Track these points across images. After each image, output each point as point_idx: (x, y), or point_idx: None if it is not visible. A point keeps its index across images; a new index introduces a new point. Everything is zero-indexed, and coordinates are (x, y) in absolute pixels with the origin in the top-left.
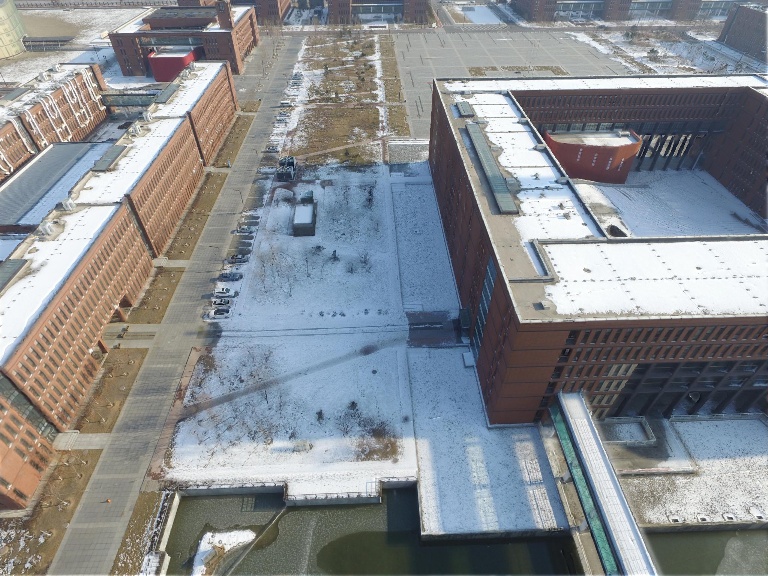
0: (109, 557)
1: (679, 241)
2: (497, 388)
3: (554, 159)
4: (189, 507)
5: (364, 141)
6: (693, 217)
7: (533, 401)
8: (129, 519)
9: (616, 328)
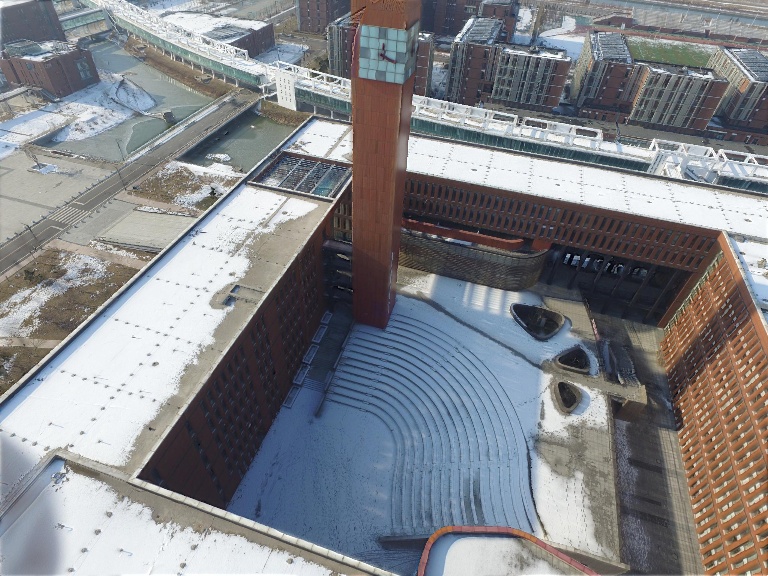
0: None
1: None
2: None
3: None
4: None
5: None
6: (382, 431)
7: None
8: None
9: None
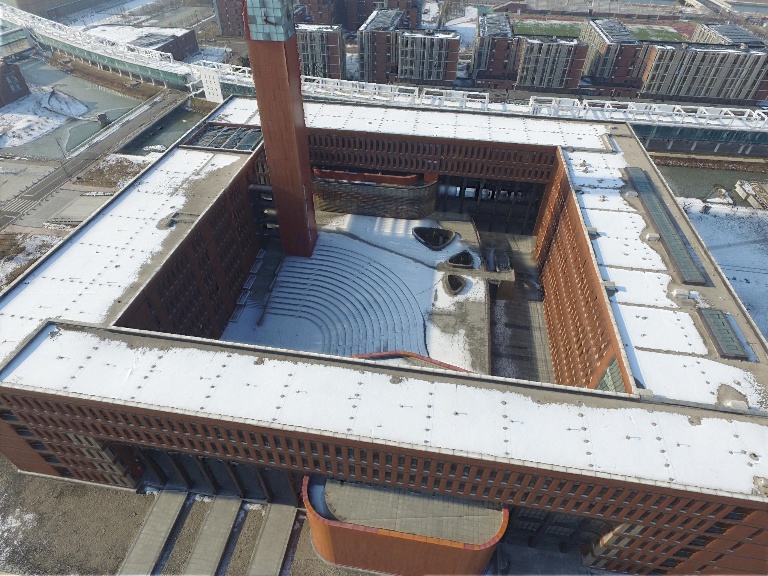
0: None
1: None
2: None
3: None
4: None
5: None
6: (313, 328)
7: None
8: None
9: None
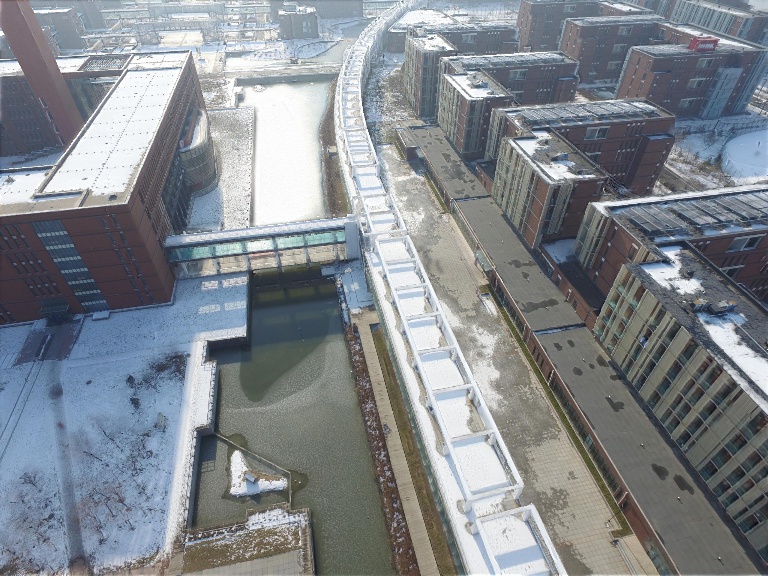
0: (248, 568)
1: (76, 144)
2: (151, 272)
3: None
4: (203, 523)
5: None
6: None
7: (164, 263)
8: (211, 569)
9: (143, 178)
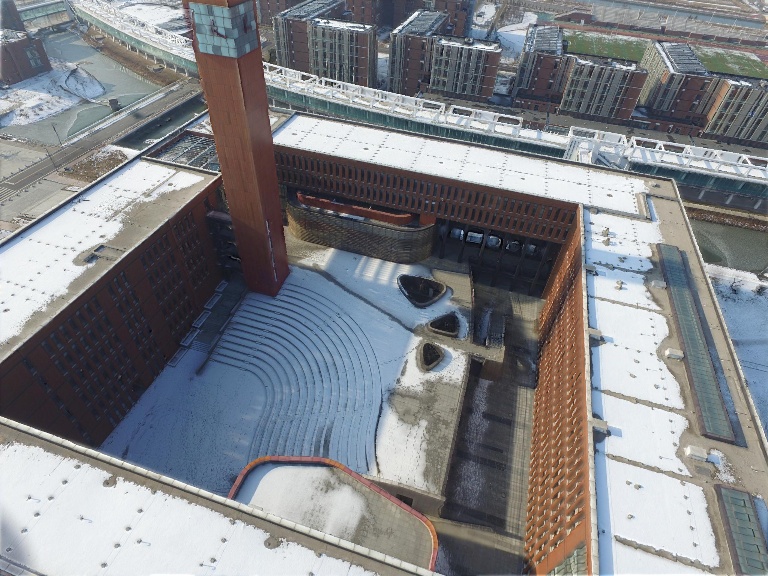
0: None
1: None
2: None
3: None
4: None
5: None
6: (257, 387)
7: None
8: None
9: None
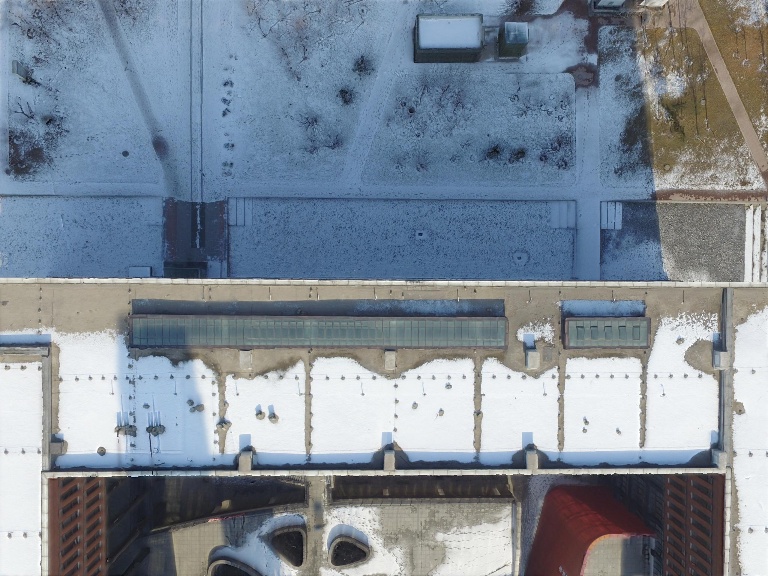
0: None
1: None
2: None
3: (326, 470)
4: None
5: (763, 151)
6: None
7: None
8: None
9: None
